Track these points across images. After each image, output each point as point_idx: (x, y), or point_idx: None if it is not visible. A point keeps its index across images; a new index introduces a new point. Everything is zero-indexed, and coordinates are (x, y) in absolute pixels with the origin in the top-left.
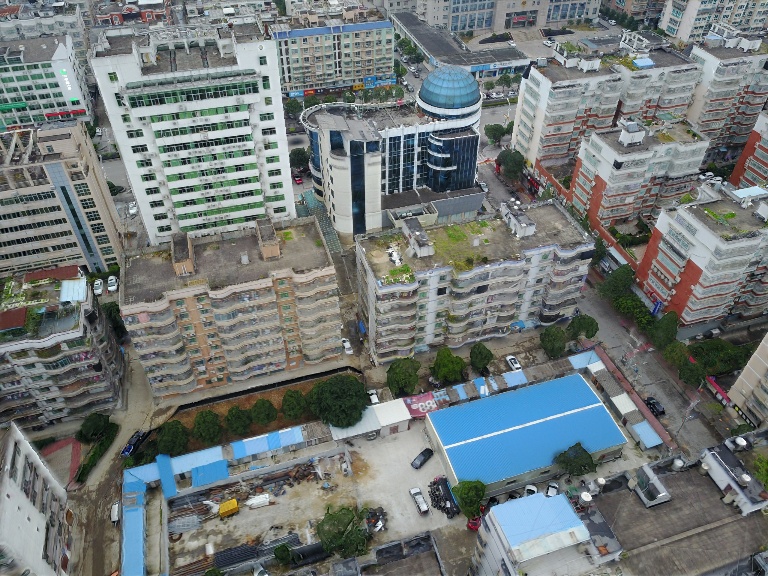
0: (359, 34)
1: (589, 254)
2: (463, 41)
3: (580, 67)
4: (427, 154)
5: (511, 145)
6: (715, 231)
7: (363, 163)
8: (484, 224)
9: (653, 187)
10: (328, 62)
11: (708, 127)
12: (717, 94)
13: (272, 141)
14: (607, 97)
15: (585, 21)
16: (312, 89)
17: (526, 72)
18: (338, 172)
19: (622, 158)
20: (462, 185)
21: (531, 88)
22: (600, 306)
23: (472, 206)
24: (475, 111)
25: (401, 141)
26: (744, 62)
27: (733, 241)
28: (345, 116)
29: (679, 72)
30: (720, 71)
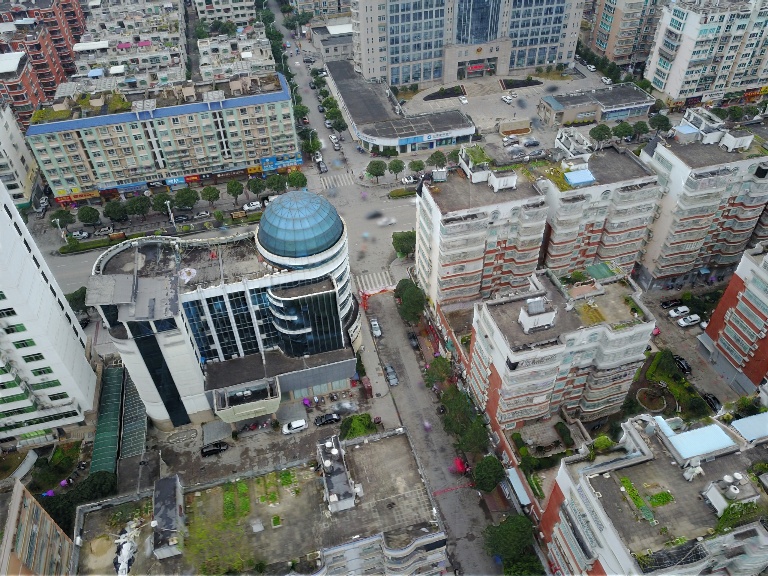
0: (246, 110)
1: (438, 543)
2: (401, 99)
3: (490, 183)
4: (269, 312)
5: (415, 269)
6: (631, 538)
7: (157, 344)
8: (286, 479)
9: (576, 378)
10: (210, 143)
11: (680, 249)
12: (689, 211)
13: (14, 323)
14: (526, 227)
15: (557, 68)
16: (195, 175)
17: (419, 187)
18: (123, 356)
19: (516, 357)
20: (325, 347)
21: (424, 211)
22: (493, 557)
23: (340, 374)
24: (332, 255)
25: (225, 301)
26: (726, 170)
27: (655, 574)
28: (159, 259)
29: (630, 189)
30: (691, 184)
